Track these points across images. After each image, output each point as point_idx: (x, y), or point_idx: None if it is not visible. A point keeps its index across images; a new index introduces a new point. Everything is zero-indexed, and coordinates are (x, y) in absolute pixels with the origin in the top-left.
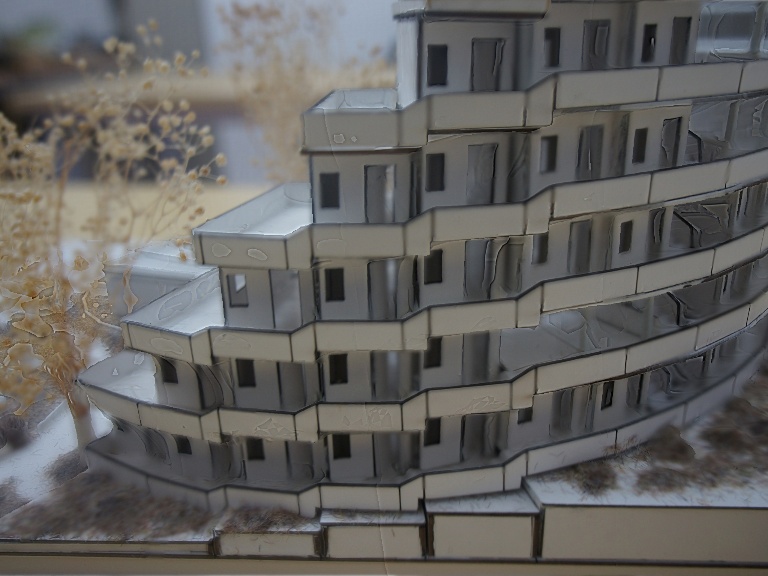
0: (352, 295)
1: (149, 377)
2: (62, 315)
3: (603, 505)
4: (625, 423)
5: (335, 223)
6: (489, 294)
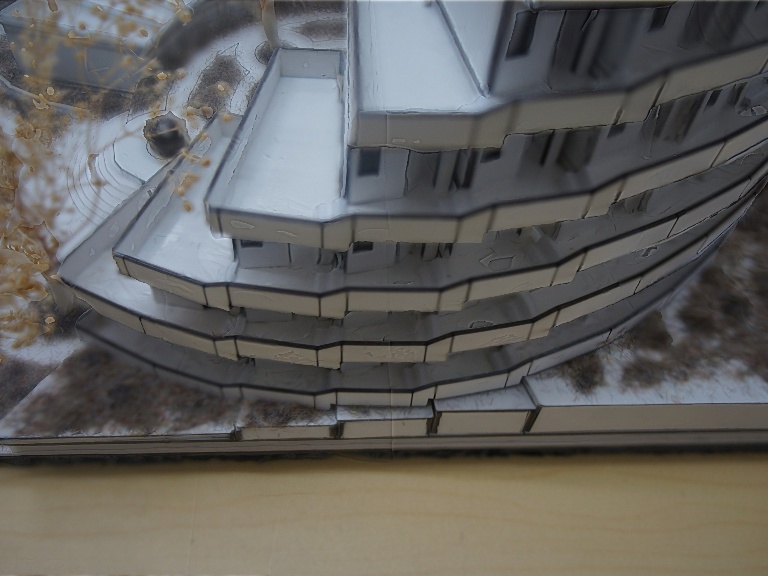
0: (381, 245)
1: None
2: None
3: (593, 405)
4: (619, 320)
5: (381, 215)
6: (520, 231)
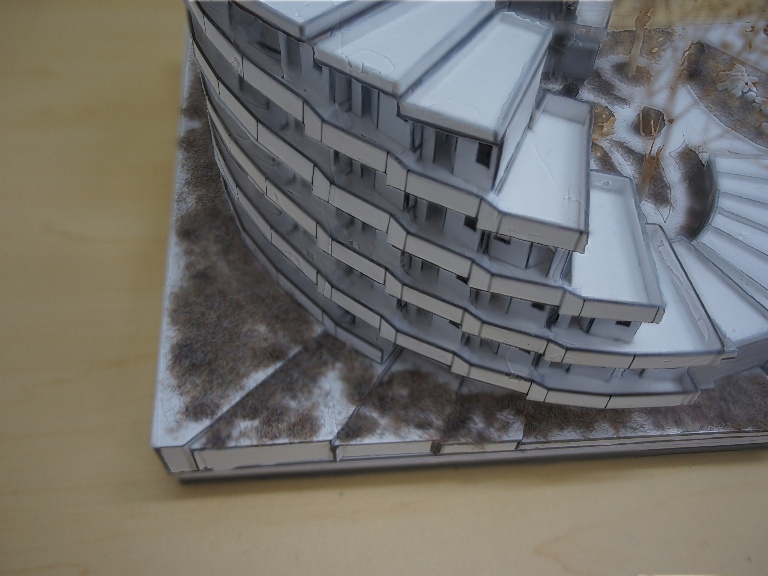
0: None
1: (595, 6)
2: None
3: None
4: None
5: None
6: None
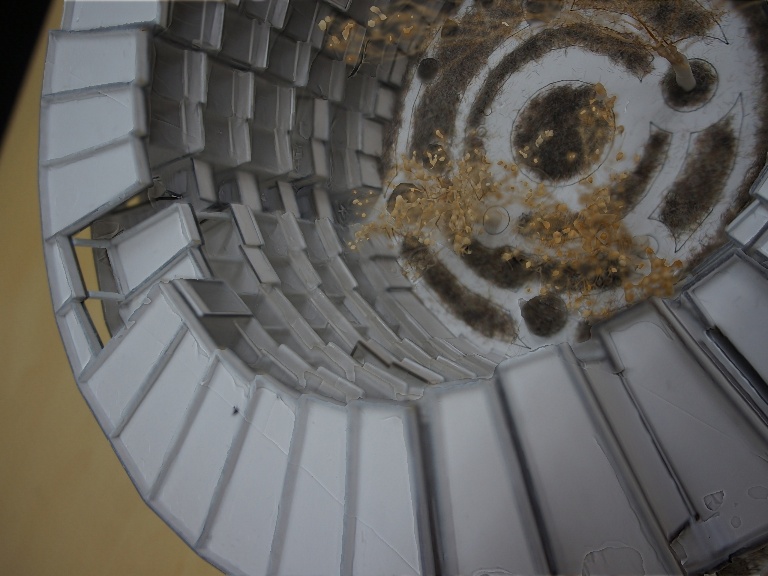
0: None
1: None
2: None
3: None
4: None
5: None
6: None
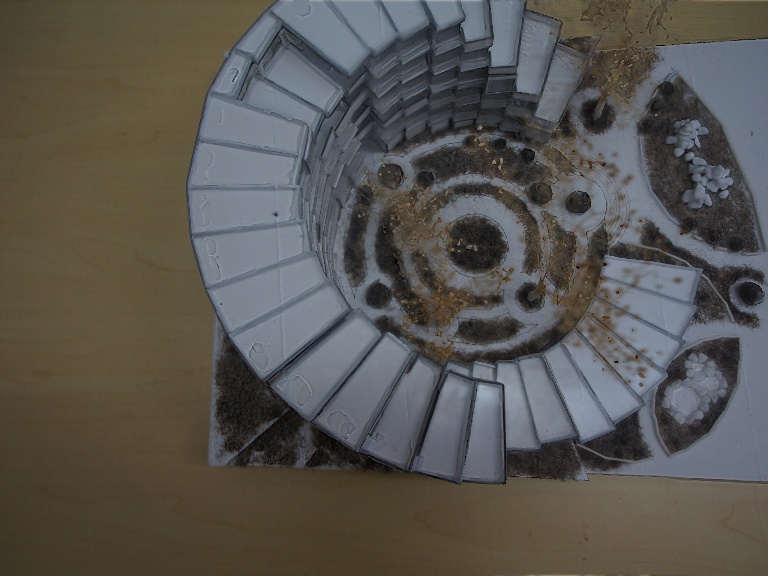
0: None
1: (565, 76)
2: (726, 278)
3: None
4: None
5: None
6: None
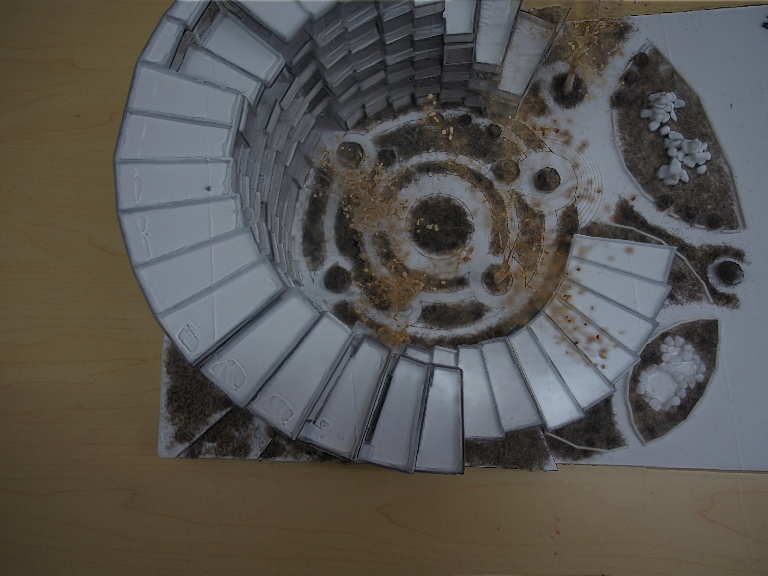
0: None
1: (530, 47)
2: (704, 257)
3: None
4: None
5: None
6: None
